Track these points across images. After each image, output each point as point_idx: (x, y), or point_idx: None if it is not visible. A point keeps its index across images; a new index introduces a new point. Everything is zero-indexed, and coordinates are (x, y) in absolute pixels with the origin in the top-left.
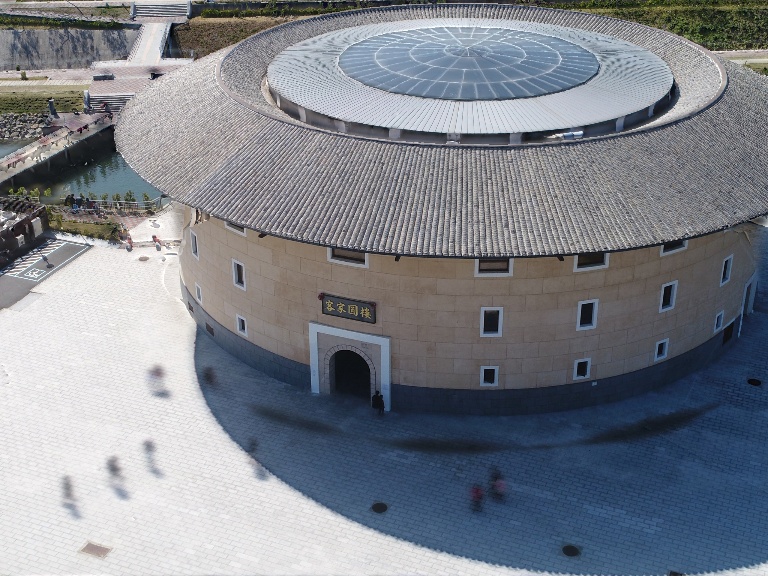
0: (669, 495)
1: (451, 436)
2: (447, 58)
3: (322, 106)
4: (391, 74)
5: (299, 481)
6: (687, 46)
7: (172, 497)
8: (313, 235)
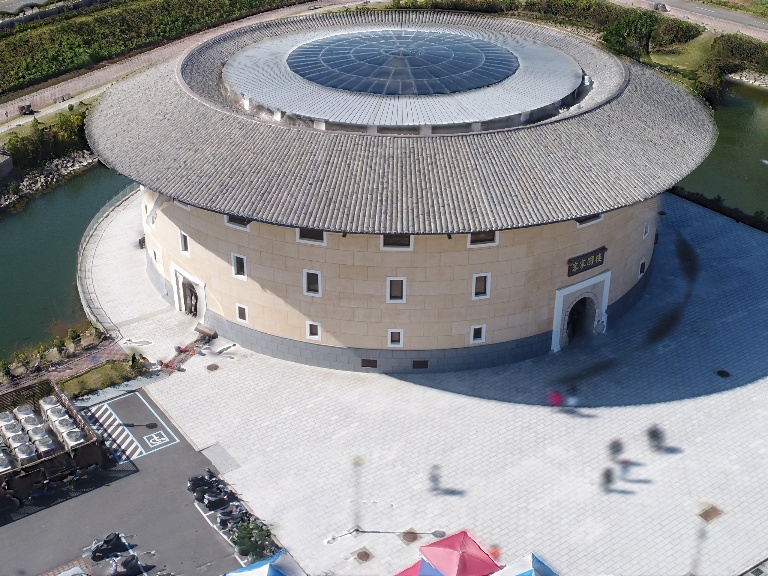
0: (763, 279)
1: (655, 321)
2: (411, 59)
3: (444, 118)
4: (415, 82)
5: (672, 395)
6: (455, 14)
7: (659, 457)
8: (626, 199)
